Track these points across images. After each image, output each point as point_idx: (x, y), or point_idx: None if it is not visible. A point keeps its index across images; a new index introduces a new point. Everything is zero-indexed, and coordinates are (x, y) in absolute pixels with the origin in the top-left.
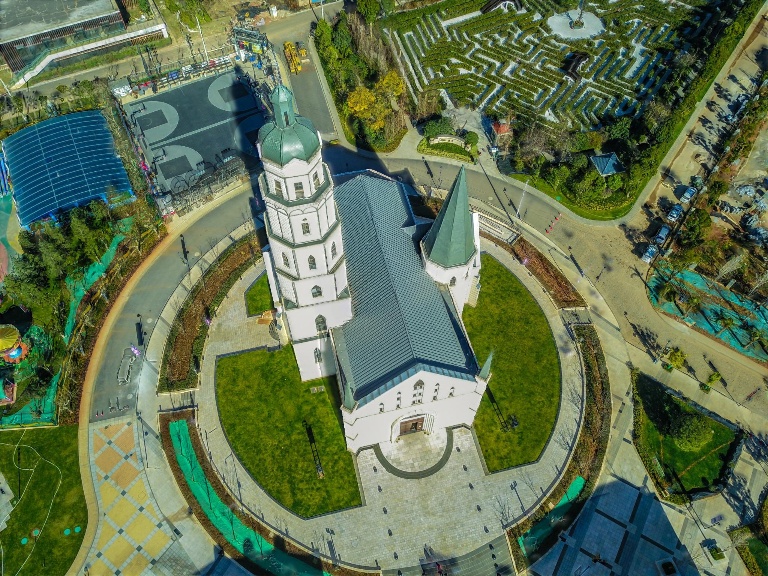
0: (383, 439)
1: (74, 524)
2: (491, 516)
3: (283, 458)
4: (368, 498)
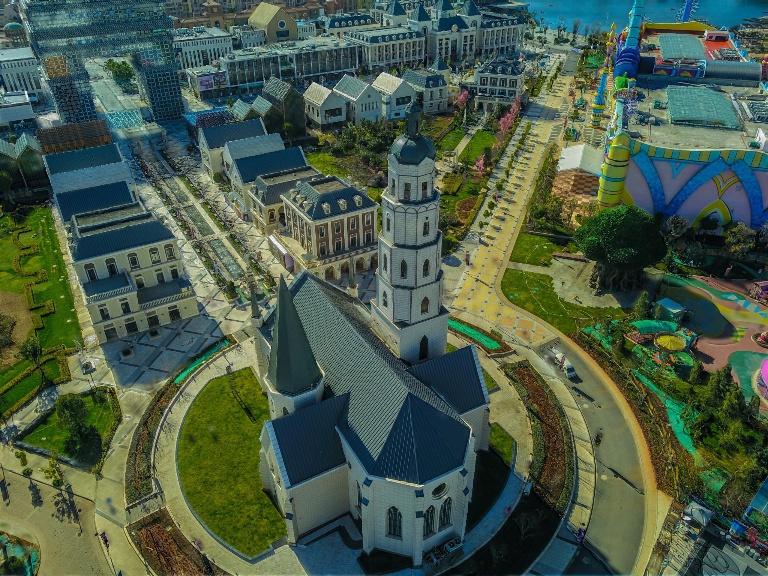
0: None
1: (516, 298)
2: (248, 349)
3: None
4: None
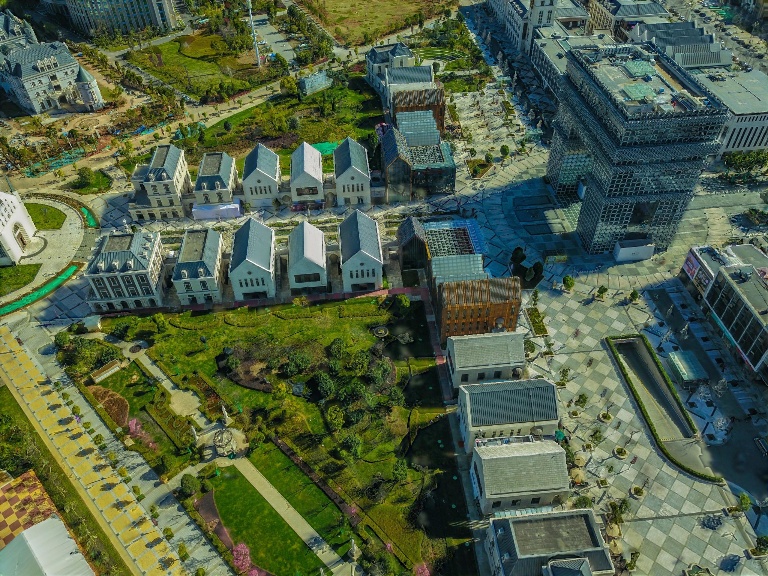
0: (20, 254)
1: None
2: (76, 231)
3: (1, 286)
4: (41, 262)
